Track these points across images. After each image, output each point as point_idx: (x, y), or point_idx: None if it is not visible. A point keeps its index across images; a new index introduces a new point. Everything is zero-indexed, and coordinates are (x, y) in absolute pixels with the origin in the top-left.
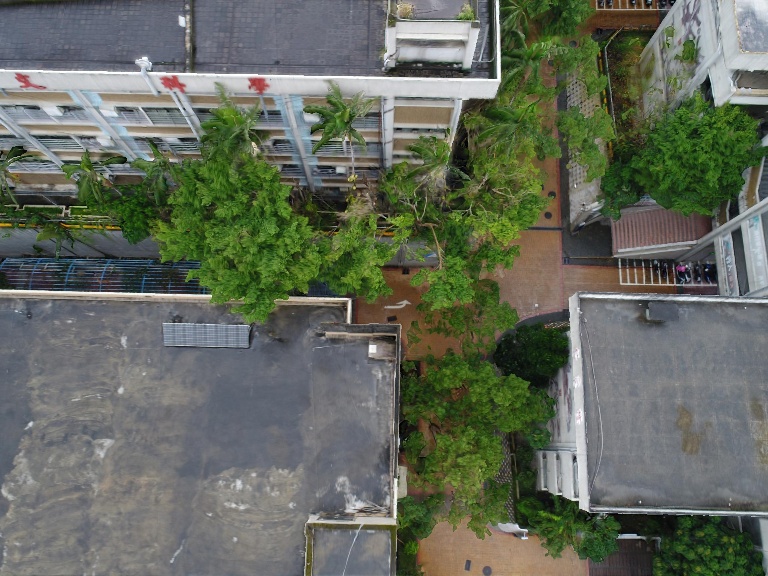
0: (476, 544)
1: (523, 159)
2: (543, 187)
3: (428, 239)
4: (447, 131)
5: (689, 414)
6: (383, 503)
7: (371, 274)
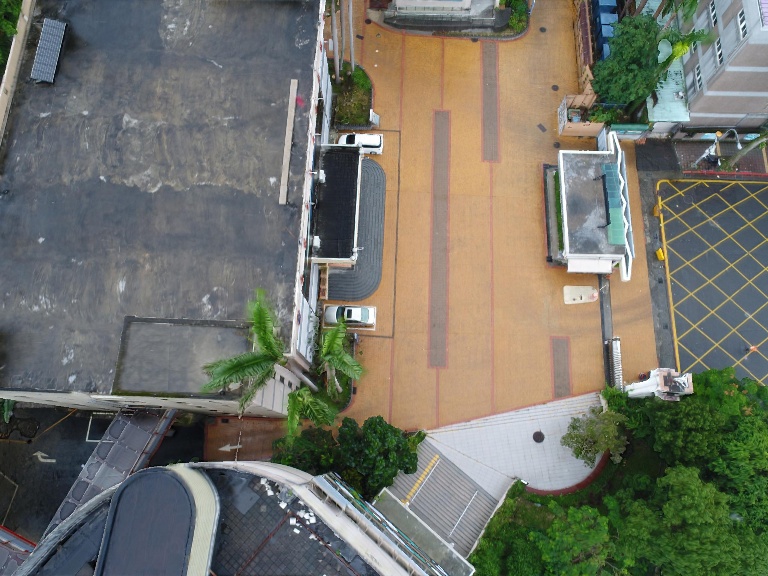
0: None
1: None
2: None
3: None
4: None
5: None
6: None
7: None
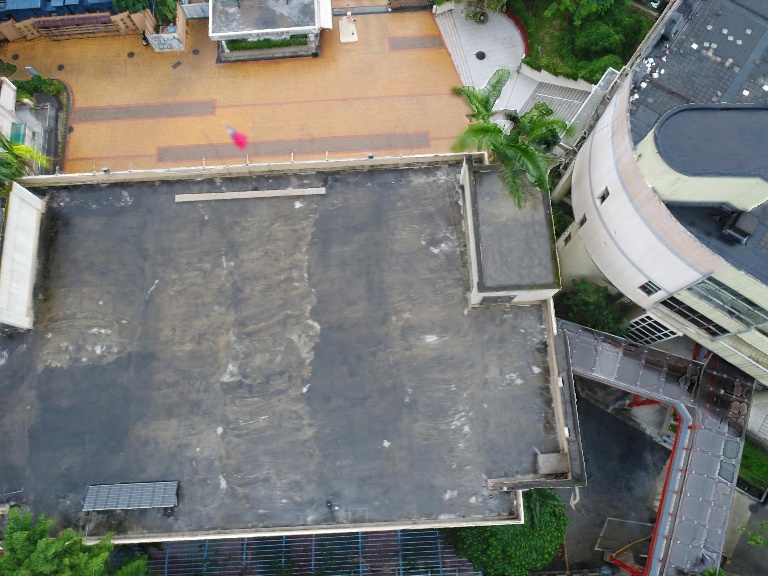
0: None
1: None
2: None
3: None
4: None
5: None
6: None
7: None
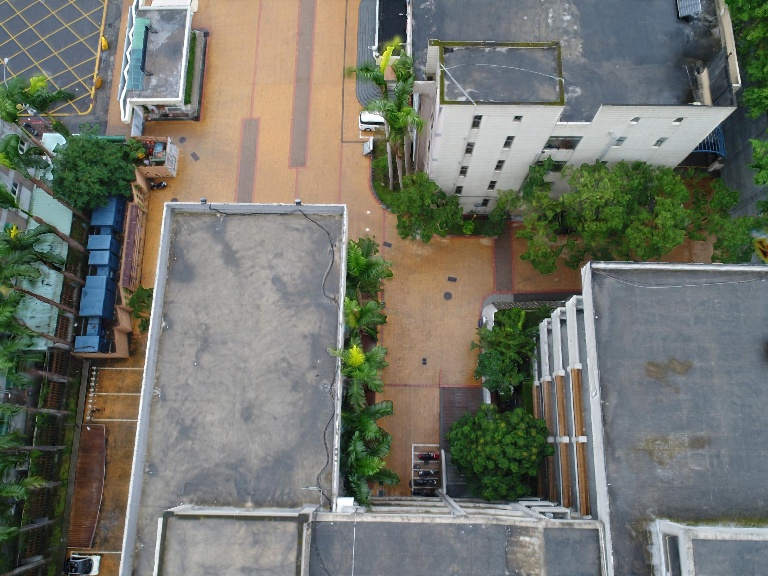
0: (470, 286)
1: None
2: None
3: None
4: None
5: (685, 372)
6: None
7: None
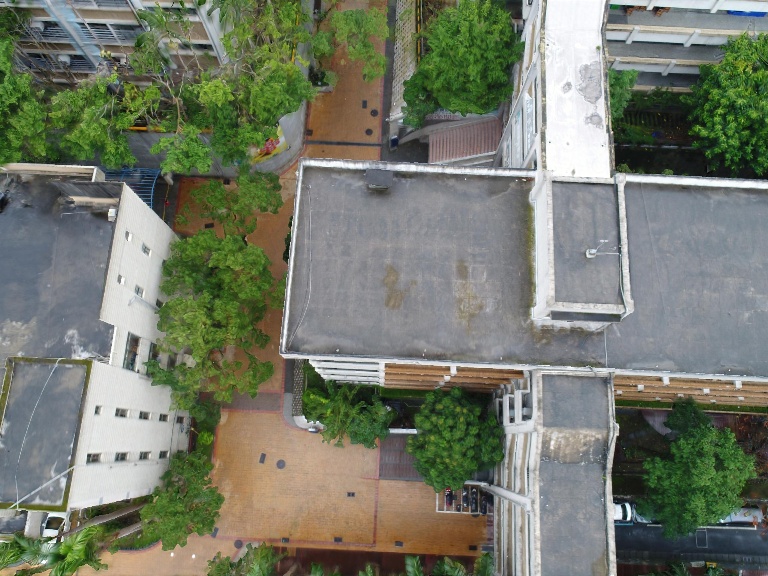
0: (272, 439)
1: (348, 79)
2: (366, 105)
3: (195, 124)
4: (180, 3)
5: (396, 273)
6: (107, 354)
7: (88, 129)
